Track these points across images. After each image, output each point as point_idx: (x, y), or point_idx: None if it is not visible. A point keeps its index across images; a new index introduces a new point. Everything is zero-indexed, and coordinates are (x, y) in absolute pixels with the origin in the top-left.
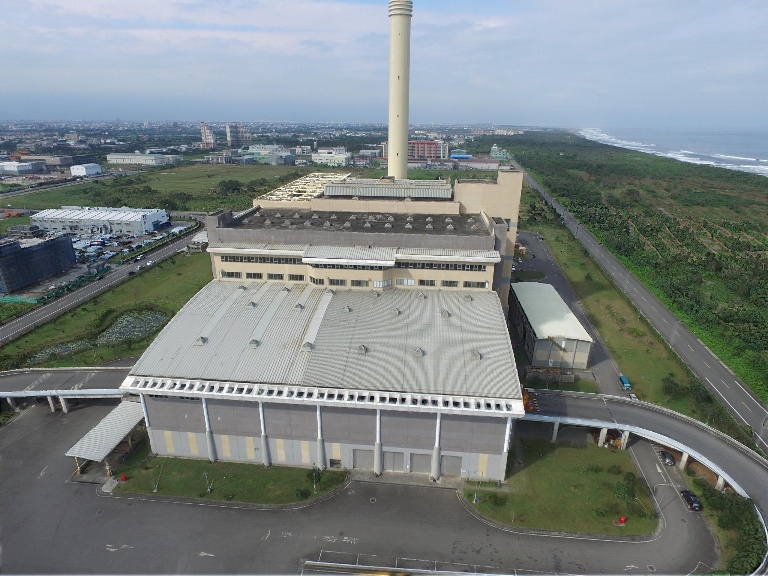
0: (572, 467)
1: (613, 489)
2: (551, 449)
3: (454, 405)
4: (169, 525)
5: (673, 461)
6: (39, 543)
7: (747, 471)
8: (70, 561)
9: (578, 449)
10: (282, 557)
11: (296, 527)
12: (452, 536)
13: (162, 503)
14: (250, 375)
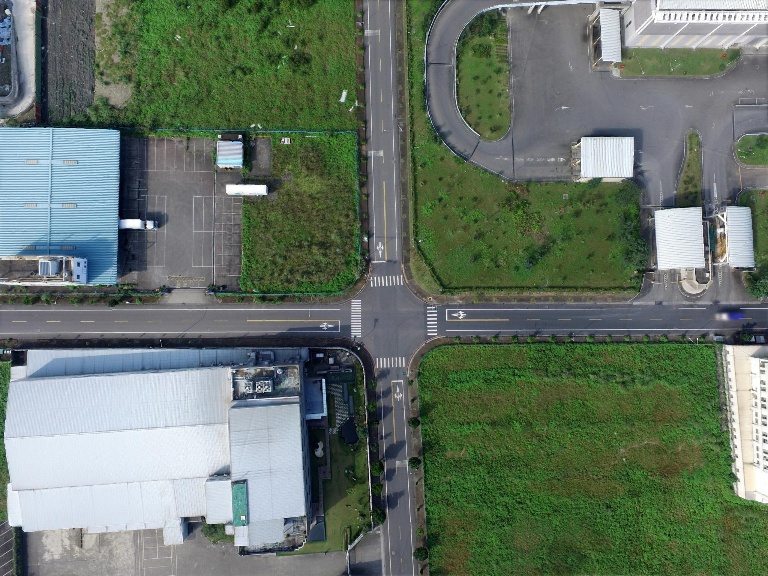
0: None
1: None
2: None
3: None
4: (663, 93)
5: None
6: (608, 109)
7: None
8: (630, 116)
9: None
10: (723, 104)
11: (724, 87)
12: None
13: (651, 80)
14: (736, 4)
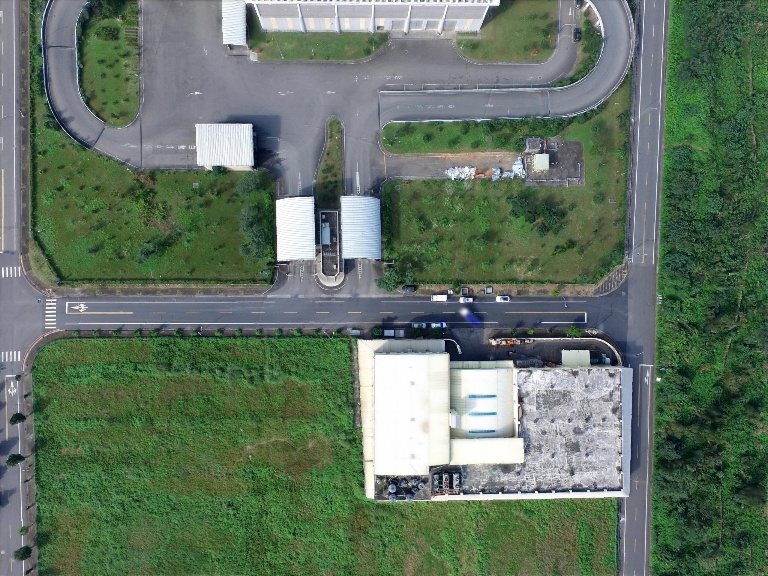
0: (520, 16)
1: (538, 33)
2: (511, 2)
3: (459, 0)
4: (303, 78)
5: (581, 6)
6: (244, 95)
7: (614, 17)
8: (267, 102)
9: (528, 0)
10: (368, 90)
11: (370, 73)
12: (449, 70)
13: (291, 65)
14: None
